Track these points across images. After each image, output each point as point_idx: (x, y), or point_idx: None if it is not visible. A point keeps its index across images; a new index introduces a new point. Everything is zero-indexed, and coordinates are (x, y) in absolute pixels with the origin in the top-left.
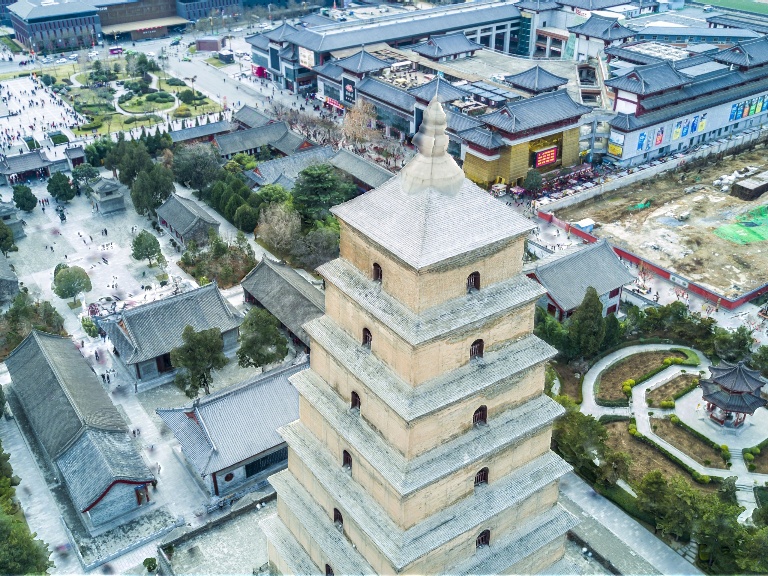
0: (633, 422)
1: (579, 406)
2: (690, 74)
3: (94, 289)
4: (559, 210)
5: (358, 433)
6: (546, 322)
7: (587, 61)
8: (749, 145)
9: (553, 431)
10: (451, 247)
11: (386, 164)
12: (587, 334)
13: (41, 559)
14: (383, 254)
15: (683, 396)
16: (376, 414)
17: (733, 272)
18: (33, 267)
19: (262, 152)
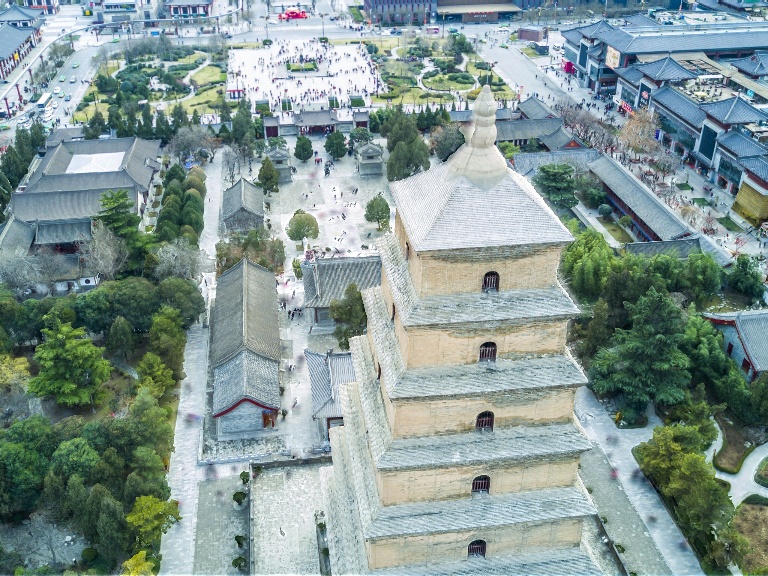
0: None
1: (714, 472)
2: None
3: (323, 238)
4: None
5: (372, 402)
6: (729, 376)
7: None
8: None
9: (677, 489)
10: (461, 239)
11: (654, 179)
12: None
13: (163, 441)
14: None
15: None
16: (384, 388)
17: None
18: (285, 209)
19: (528, 144)
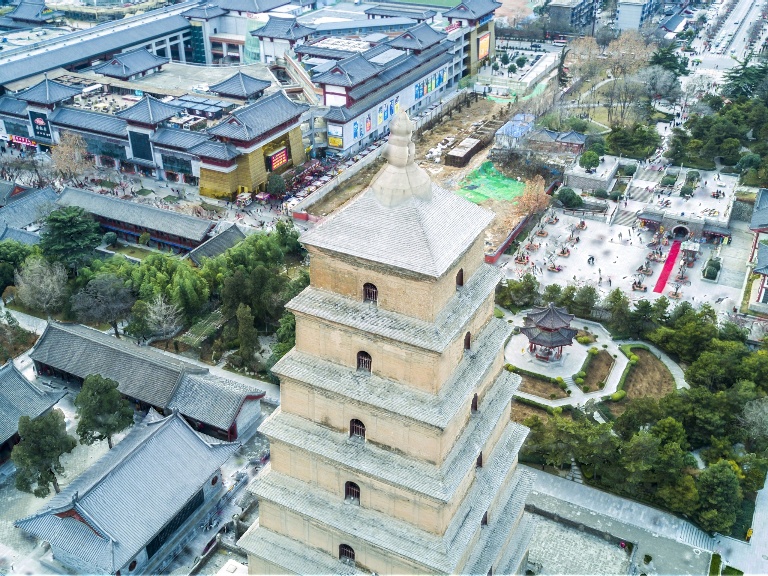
0: None
1: None
2: (380, 62)
3: None
4: (309, 207)
5: (370, 459)
6: None
7: (276, 62)
8: (437, 119)
9: None
10: (451, 249)
11: (113, 195)
12: None
13: None
14: (379, 272)
15: (506, 346)
16: (391, 433)
17: None
18: None
19: None
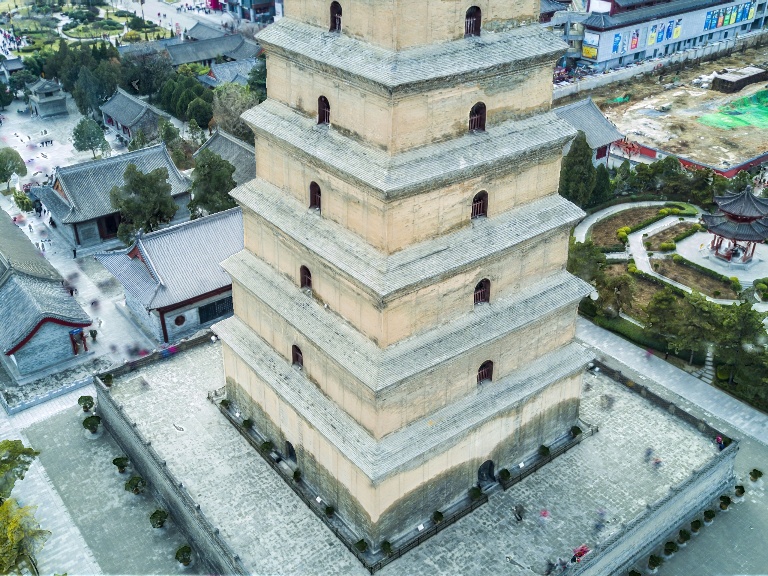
0: (632, 262)
1: (574, 237)
2: None
3: (31, 178)
4: None
5: (327, 144)
6: None
7: None
8: (725, 53)
9: None
10: None
11: None
12: (576, 182)
13: None
14: None
15: (684, 239)
16: (349, 110)
17: (721, 151)
18: None
19: (217, 62)
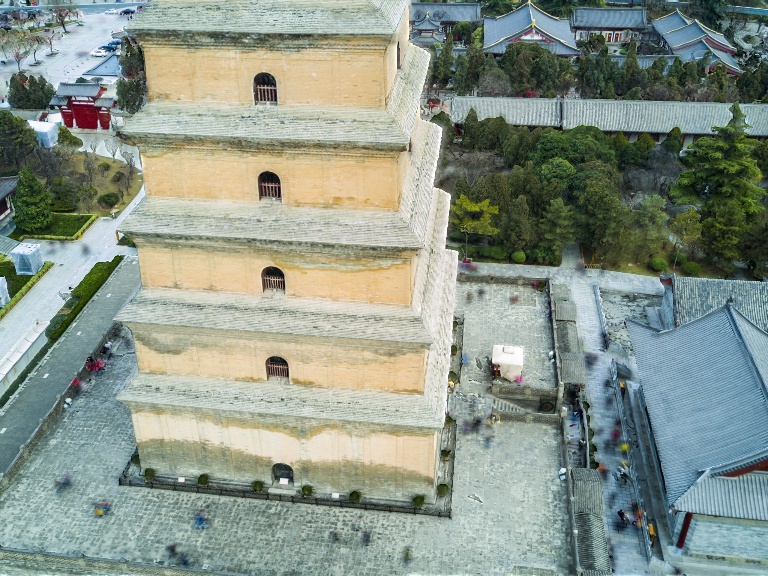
0: None
1: None
2: None
3: None
4: None
5: None
6: None
7: None
8: None
9: None
10: None
11: None
12: None
13: (601, 236)
14: None
15: None
16: None
17: None
18: None
19: None
